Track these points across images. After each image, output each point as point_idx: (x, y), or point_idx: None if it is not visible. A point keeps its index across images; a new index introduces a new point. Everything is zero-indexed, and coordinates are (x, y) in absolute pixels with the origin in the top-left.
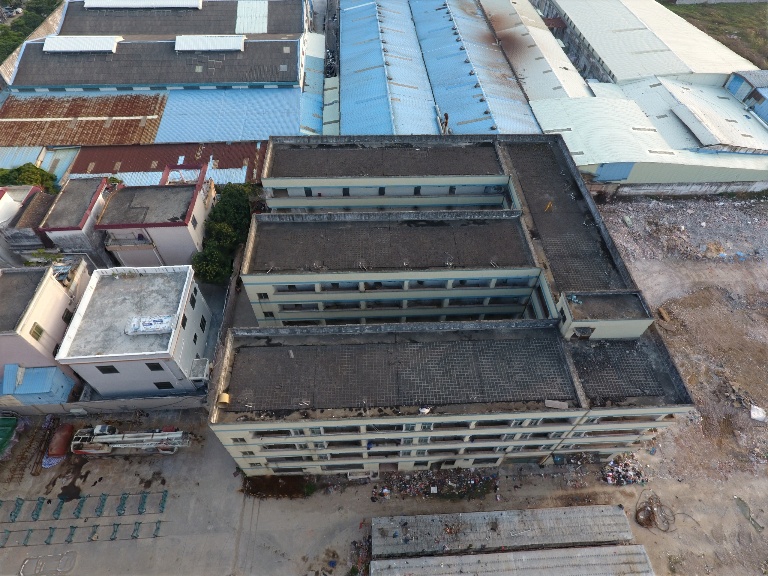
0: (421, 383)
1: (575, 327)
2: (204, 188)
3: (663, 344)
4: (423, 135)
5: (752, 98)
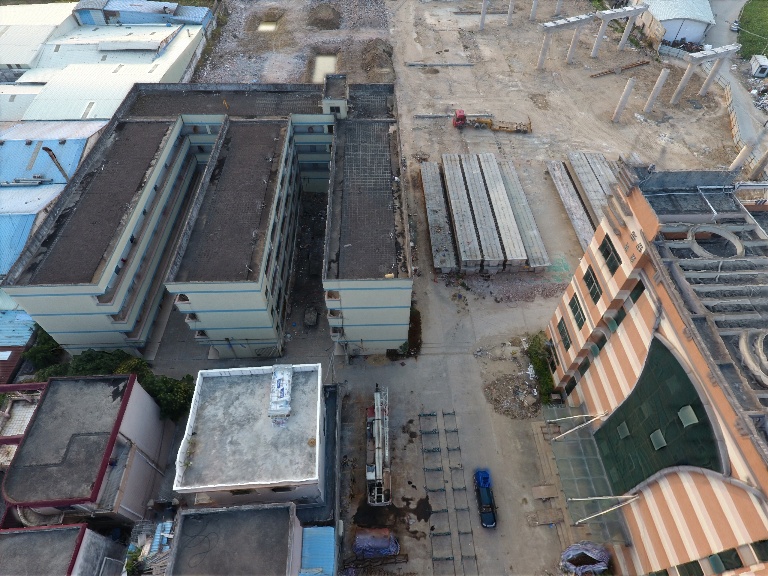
0: (376, 179)
1: (347, 105)
2: (23, 410)
3: (357, 85)
4: (86, 158)
5: (109, 17)
